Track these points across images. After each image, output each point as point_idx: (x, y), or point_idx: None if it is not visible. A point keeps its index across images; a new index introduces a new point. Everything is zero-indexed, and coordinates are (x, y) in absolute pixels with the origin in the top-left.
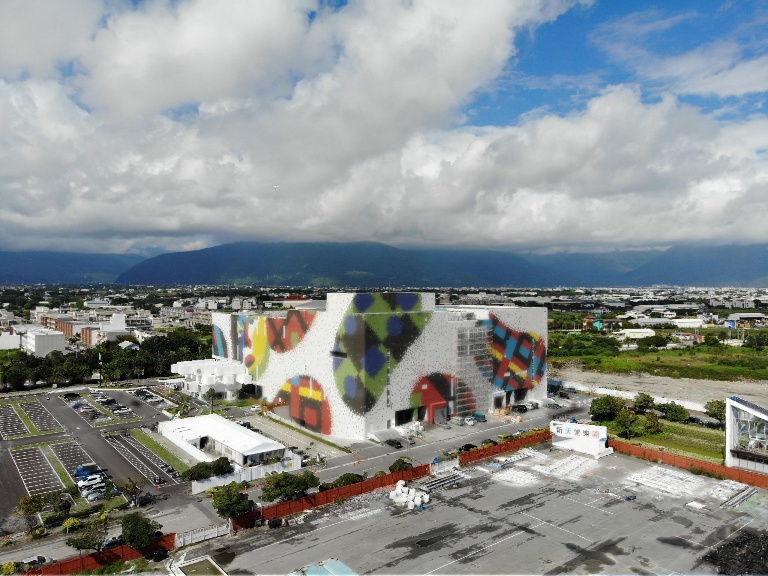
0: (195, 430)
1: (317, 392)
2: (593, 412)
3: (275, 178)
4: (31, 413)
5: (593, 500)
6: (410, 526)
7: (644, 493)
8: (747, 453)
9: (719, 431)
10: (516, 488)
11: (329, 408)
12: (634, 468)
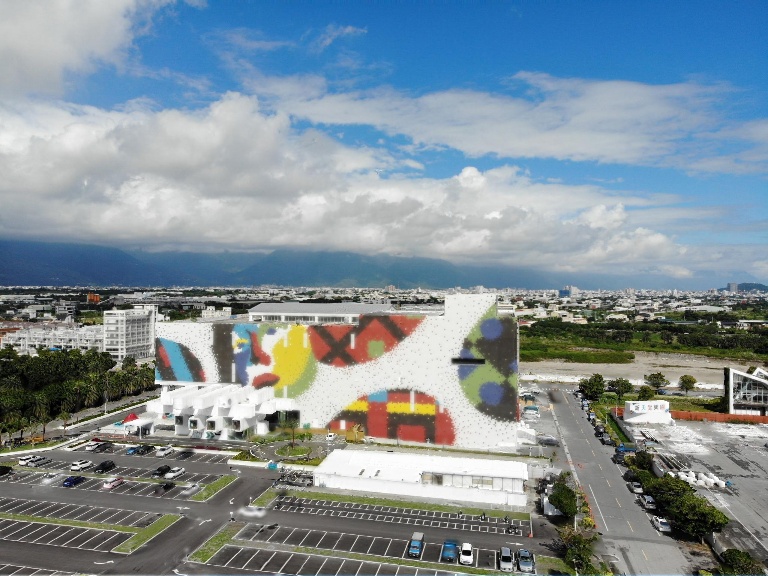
0: (390, 470)
1: (426, 405)
2: (592, 393)
3: (375, 160)
4: (13, 509)
5: (759, 452)
6: (764, 498)
7: (758, 441)
8: (743, 405)
9: (661, 395)
10: (711, 455)
11: (451, 420)
12: (707, 427)
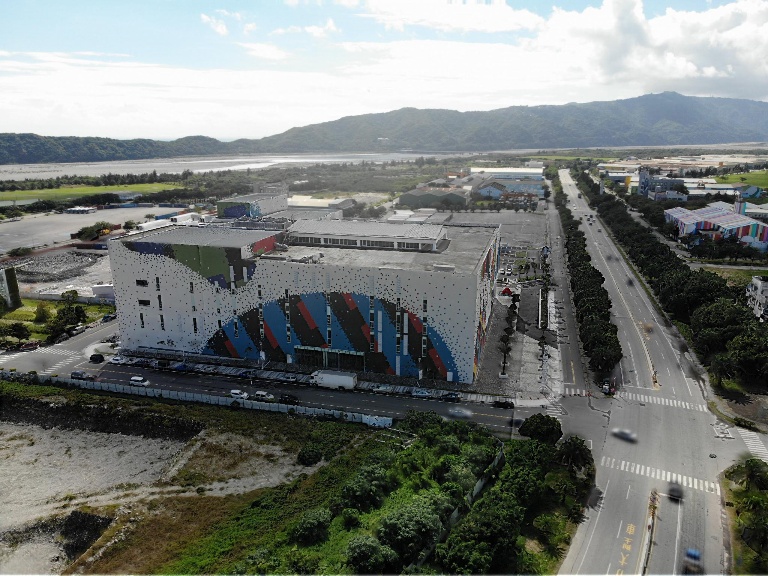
0: None
1: None
2: None
3: (332, 104)
4: None
5: None
6: None
7: None
8: None
9: None
10: None
11: None
12: None
